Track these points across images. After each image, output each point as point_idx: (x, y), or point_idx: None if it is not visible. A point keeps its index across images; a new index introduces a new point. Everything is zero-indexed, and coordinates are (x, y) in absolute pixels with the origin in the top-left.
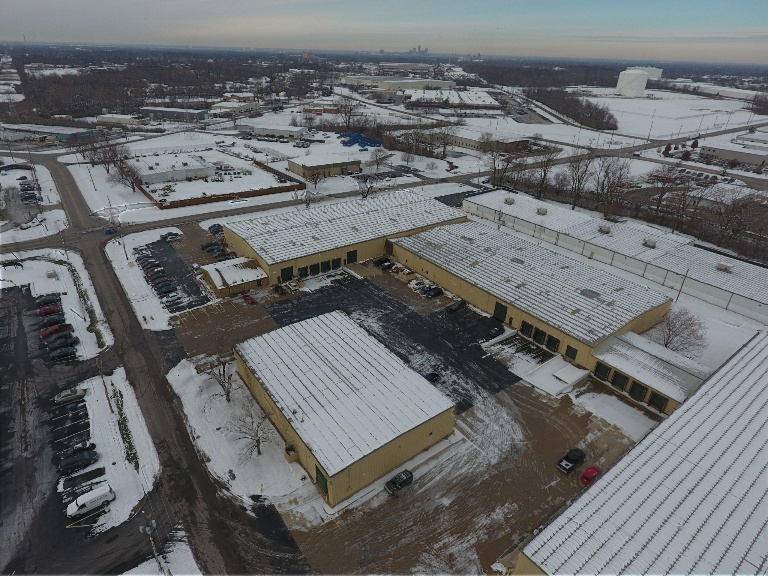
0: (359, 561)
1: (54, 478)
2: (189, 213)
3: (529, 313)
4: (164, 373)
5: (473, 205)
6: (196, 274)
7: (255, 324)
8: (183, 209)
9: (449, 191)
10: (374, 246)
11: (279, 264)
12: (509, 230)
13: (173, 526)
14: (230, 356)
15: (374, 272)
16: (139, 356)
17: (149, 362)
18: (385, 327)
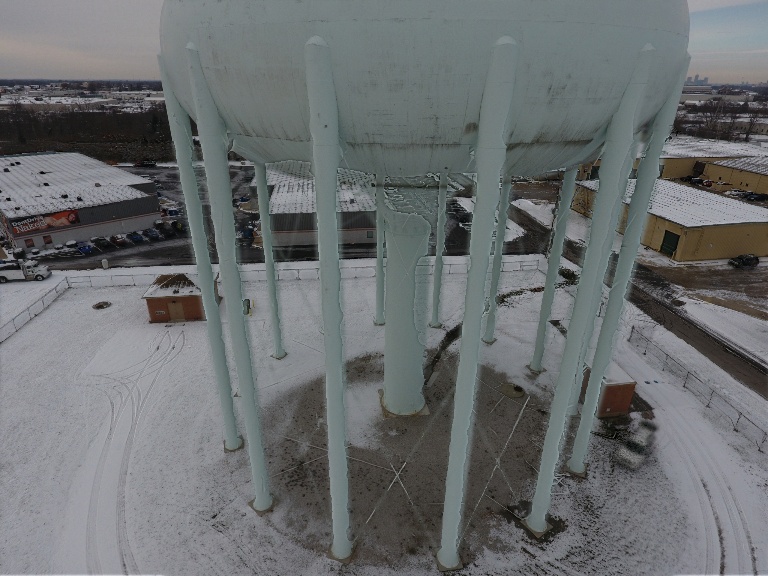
0: (711, 284)
1: (455, 222)
2: None
3: None
4: None
5: None
6: None
7: None
8: None
9: None
10: (682, 166)
11: None
12: None
13: (546, 248)
14: None
15: None
16: None
17: None
18: None
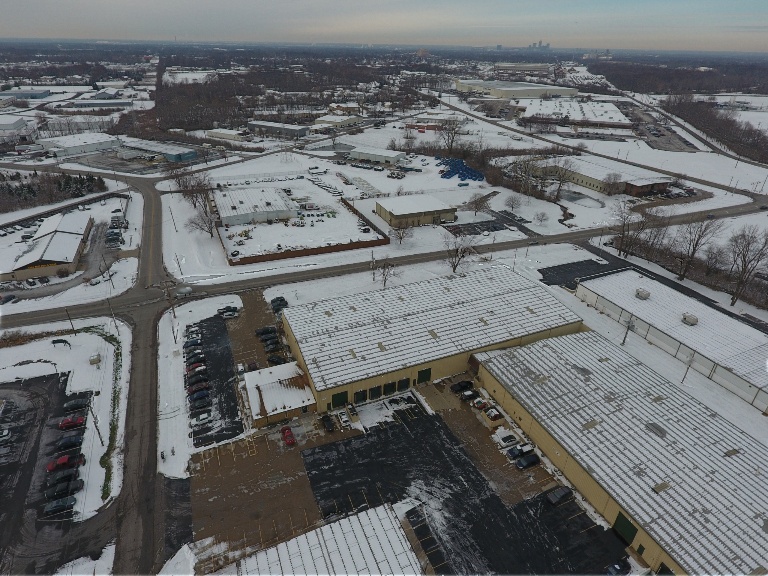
0: None
1: None
2: (257, 274)
3: (675, 559)
4: (156, 568)
5: (591, 294)
6: (239, 379)
7: (285, 486)
8: (252, 267)
9: (560, 259)
10: (454, 362)
11: (330, 390)
12: (640, 341)
13: None
14: (241, 549)
15: (450, 403)
16: (138, 526)
17: (146, 541)
18: (452, 523)
